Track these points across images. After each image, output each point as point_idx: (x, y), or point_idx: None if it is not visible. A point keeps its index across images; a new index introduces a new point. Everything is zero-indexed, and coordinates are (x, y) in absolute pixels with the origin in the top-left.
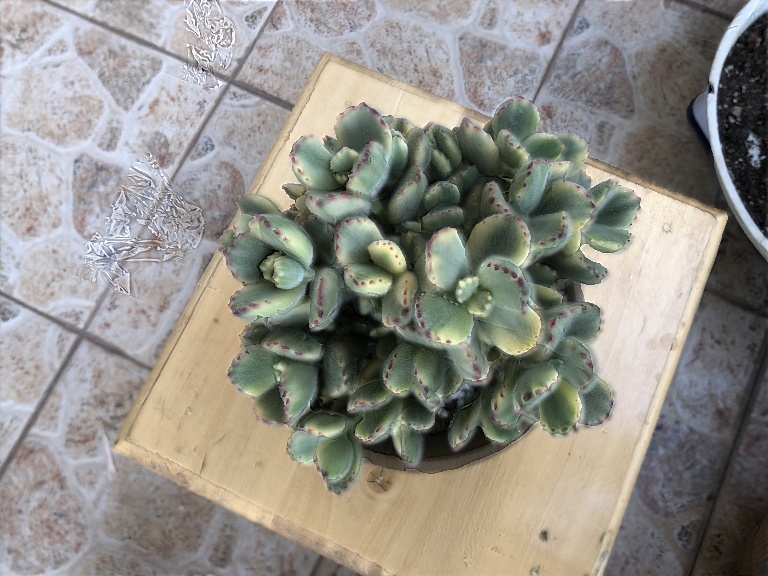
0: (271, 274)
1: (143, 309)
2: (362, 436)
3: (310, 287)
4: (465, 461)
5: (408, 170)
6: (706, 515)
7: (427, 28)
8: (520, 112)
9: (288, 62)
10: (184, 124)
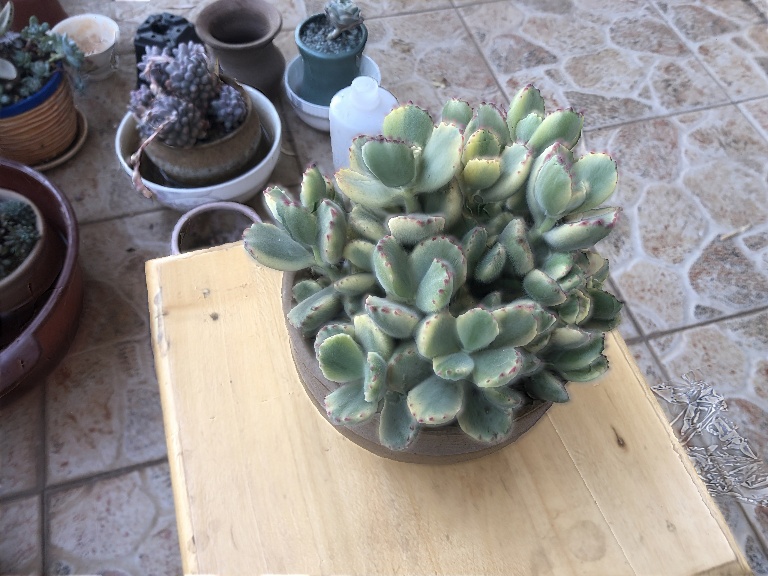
0: None
1: None
2: None
3: None
4: None
5: None
6: None
7: None
8: None
9: None
10: None
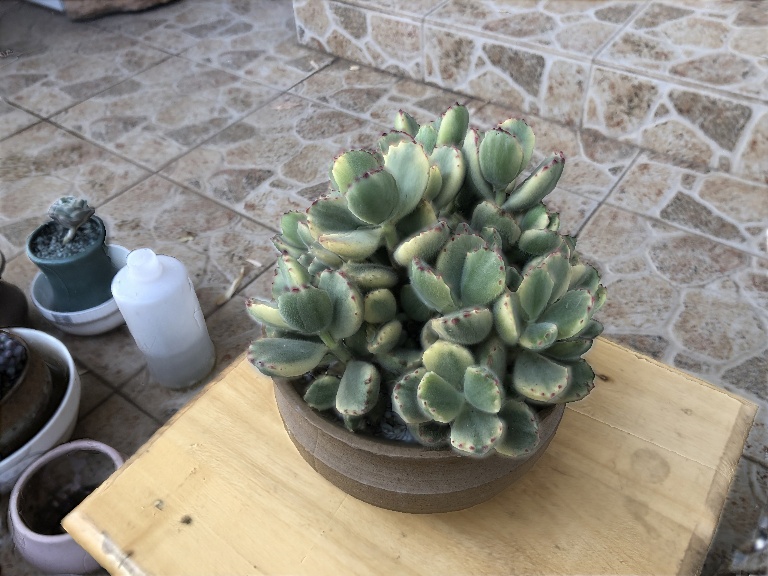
0: None
1: None
2: None
3: None
4: None
5: None
6: None
7: None
8: None
9: None
10: None
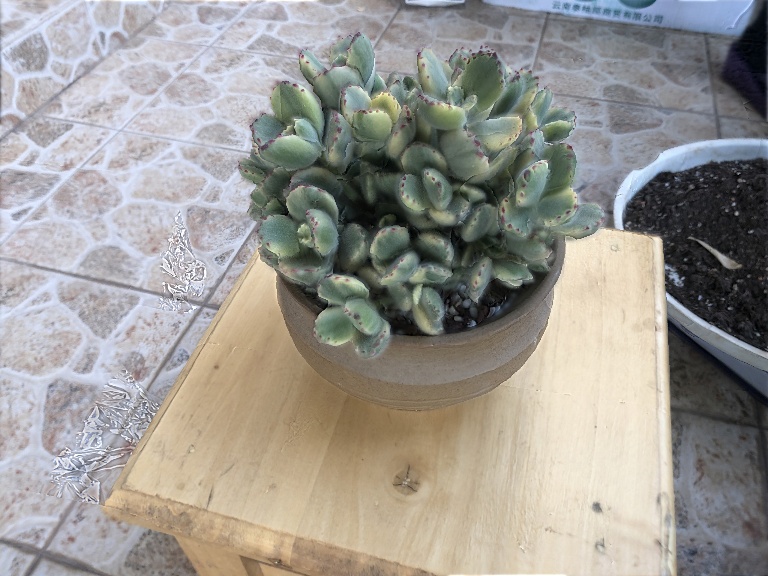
0: None
1: (113, 516)
2: (388, 275)
3: None
4: (490, 330)
5: None
6: None
7: None
8: None
9: None
10: (160, 342)
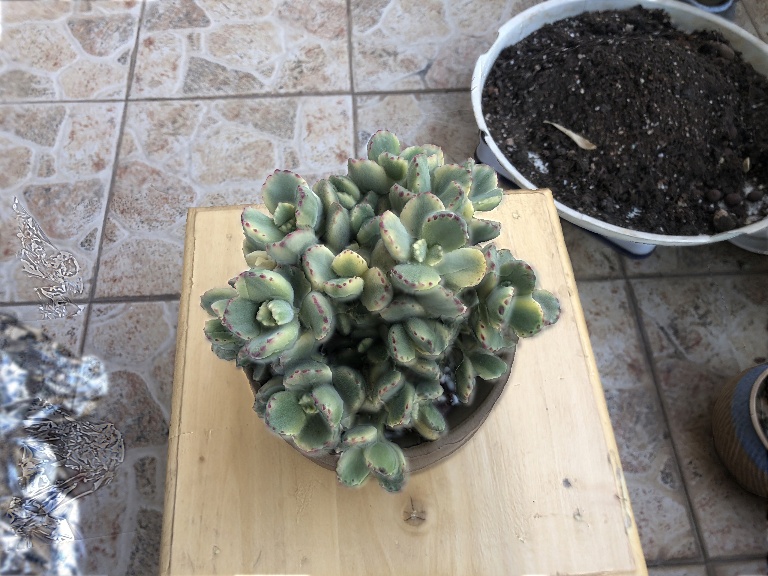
0: (268, 319)
1: (95, 546)
2: (396, 421)
3: (301, 319)
4: (480, 417)
5: (329, 208)
6: (672, 452)
7: (245, 187)
8: (384, 141)
9: (137, 263)
10: (62, 357)
